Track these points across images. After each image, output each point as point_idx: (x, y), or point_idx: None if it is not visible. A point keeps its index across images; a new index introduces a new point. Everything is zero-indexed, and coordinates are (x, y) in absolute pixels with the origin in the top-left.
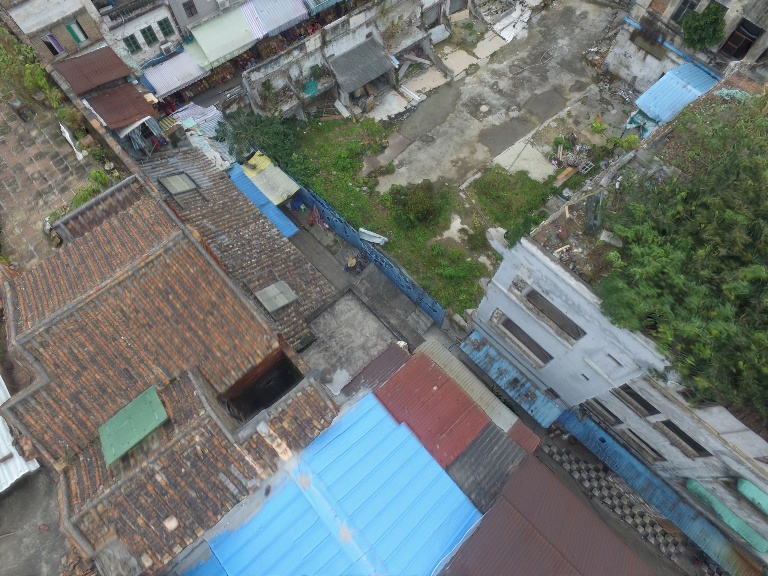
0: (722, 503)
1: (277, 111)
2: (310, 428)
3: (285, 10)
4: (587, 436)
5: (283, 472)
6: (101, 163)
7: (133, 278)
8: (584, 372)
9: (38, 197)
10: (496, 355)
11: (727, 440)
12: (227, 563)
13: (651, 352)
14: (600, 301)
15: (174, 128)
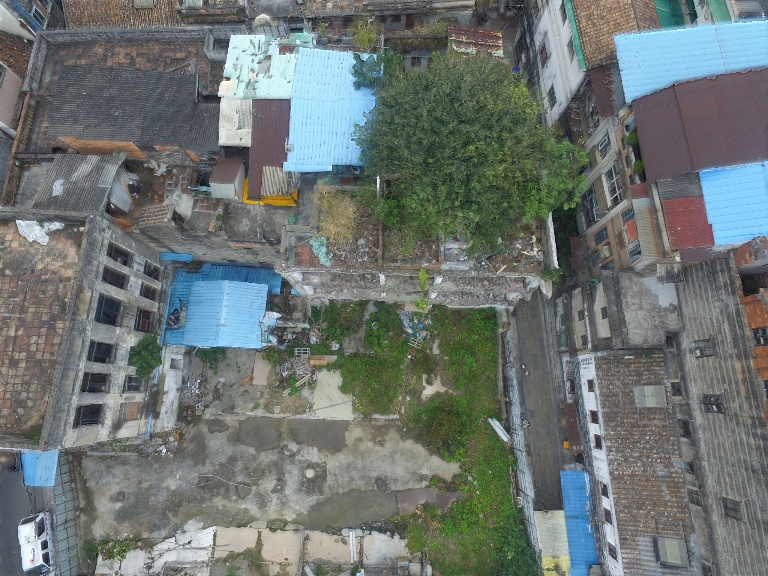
0: None
1: None
2: None
3: None
4: None
5: None
6: None
7: None
8: None
9: None
10: None
11: None
12: None
13: None
14: None
15: None
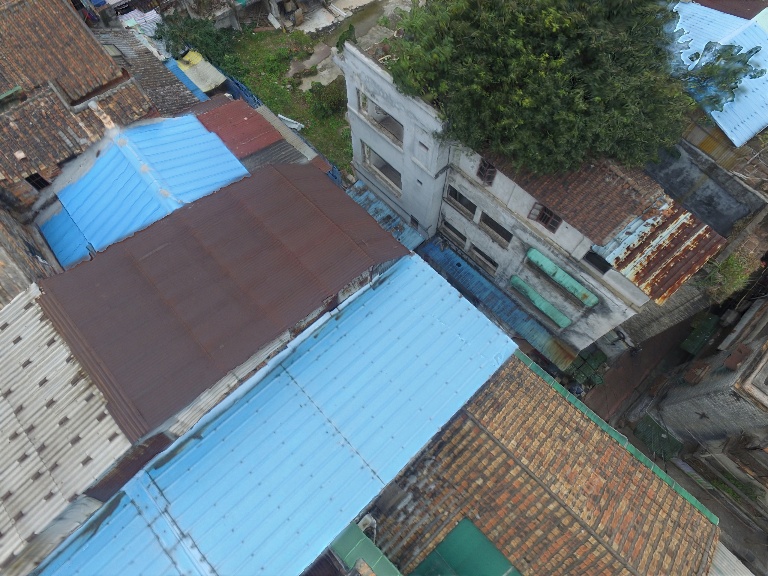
0: (536, 292)
1: (211, 16)
2: (131, 113)
3: None
4: (446, 261)
5: (109, 140)
6: None
7: (9, 12)
8: (417, 176)
9: None
10: (374, 198)
11: (512, 209)
12: (68, 205)
13: (431, 116)
14: None
15: (104, 6)
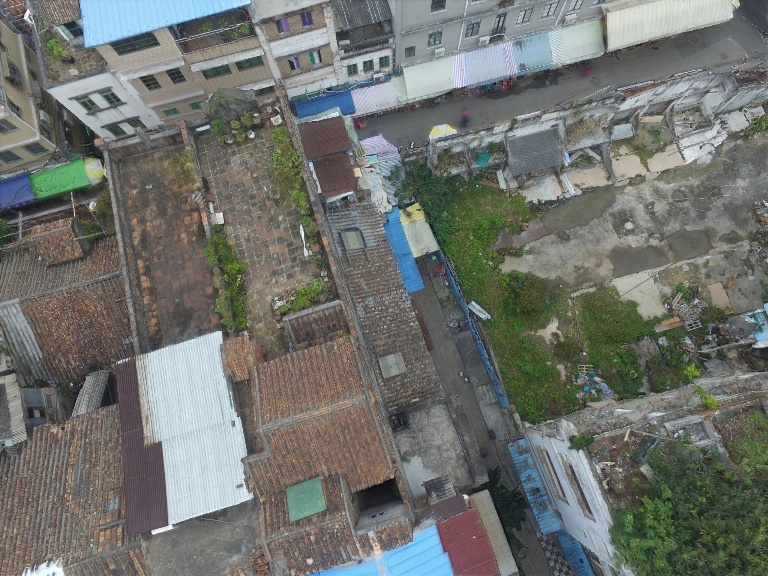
0: None
1: (446, 172)
2: (395, 542)
3: (490, 68)
4: (571, 553)
5: (372, 558)
6: (319, 269)
7: (330, 414)
8: (585, 532)
9: (273, 275)
10: (532, 464)
11: None
12: None
13: (628, 572)
14: (612, 522)
15: (365, 193)
